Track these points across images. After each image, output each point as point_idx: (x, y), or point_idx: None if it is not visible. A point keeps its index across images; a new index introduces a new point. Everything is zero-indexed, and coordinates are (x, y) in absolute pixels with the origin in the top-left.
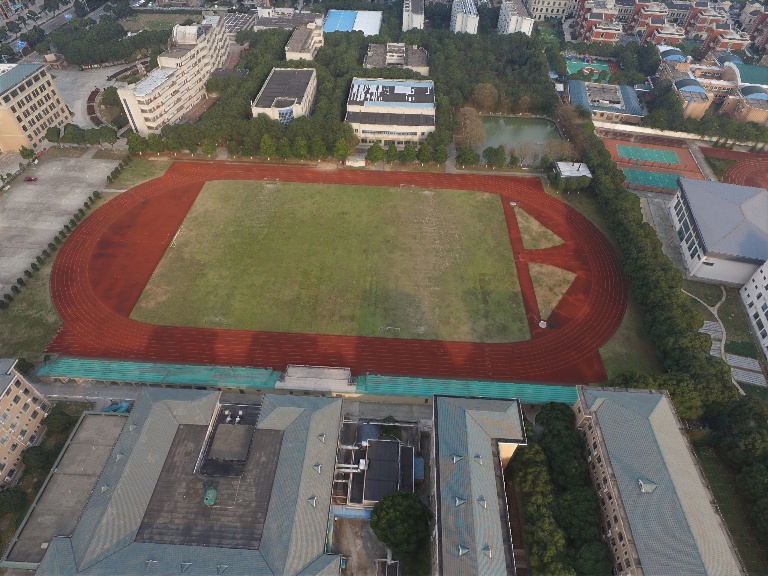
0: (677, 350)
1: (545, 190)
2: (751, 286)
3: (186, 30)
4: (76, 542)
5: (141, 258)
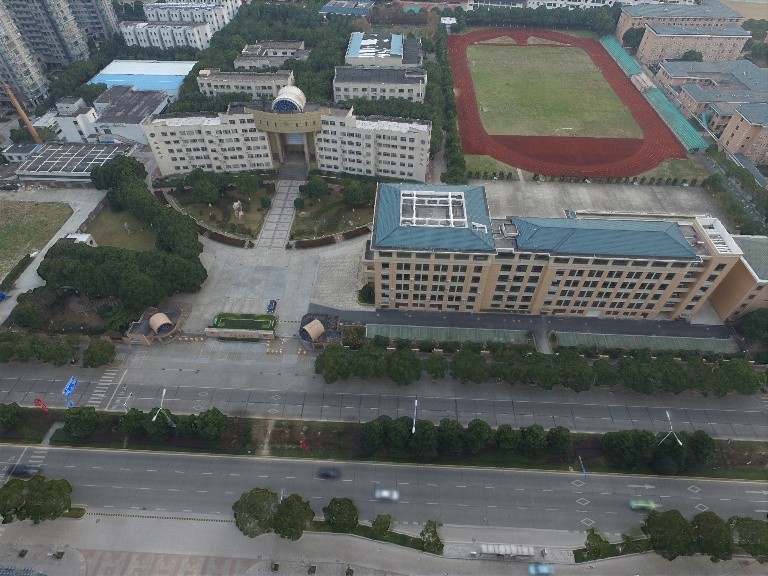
0: (586, 14)
1: (459, 35)
2: (531, 5)
3: (295, 94)
4: (767, 98)
5: (593, 144)
